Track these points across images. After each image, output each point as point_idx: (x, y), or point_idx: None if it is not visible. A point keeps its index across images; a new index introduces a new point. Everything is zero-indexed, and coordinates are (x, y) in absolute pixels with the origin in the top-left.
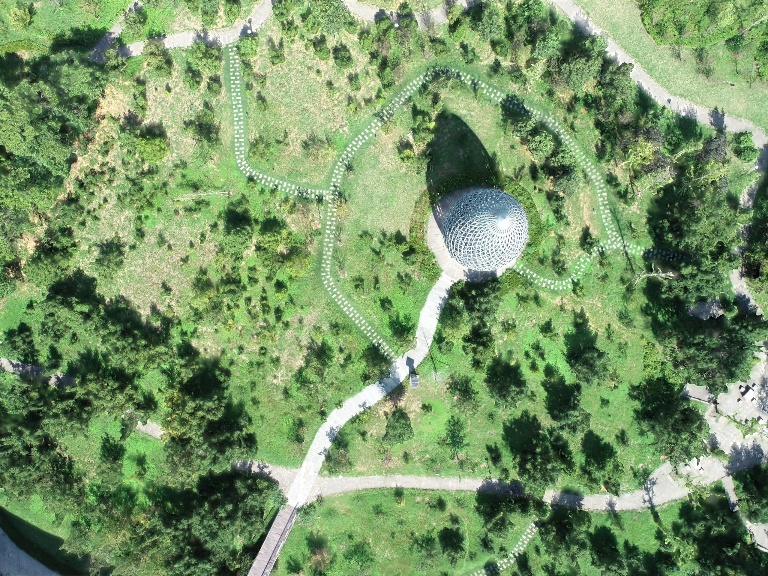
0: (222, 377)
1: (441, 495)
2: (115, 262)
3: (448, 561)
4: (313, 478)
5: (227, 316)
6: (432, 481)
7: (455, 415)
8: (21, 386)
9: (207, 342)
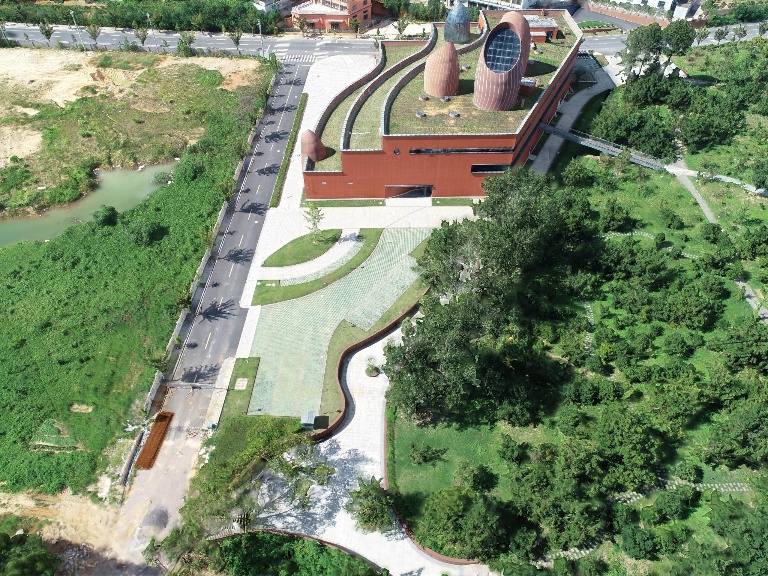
0: (728, 140)
1: (705, 220)
2: (767, 108)
3: (662, 225)
4: (685, 174)
5: (762, 143)
6: (711, 217)
7: (764, 221)
8: (689, 84)
9: (741, 139)
